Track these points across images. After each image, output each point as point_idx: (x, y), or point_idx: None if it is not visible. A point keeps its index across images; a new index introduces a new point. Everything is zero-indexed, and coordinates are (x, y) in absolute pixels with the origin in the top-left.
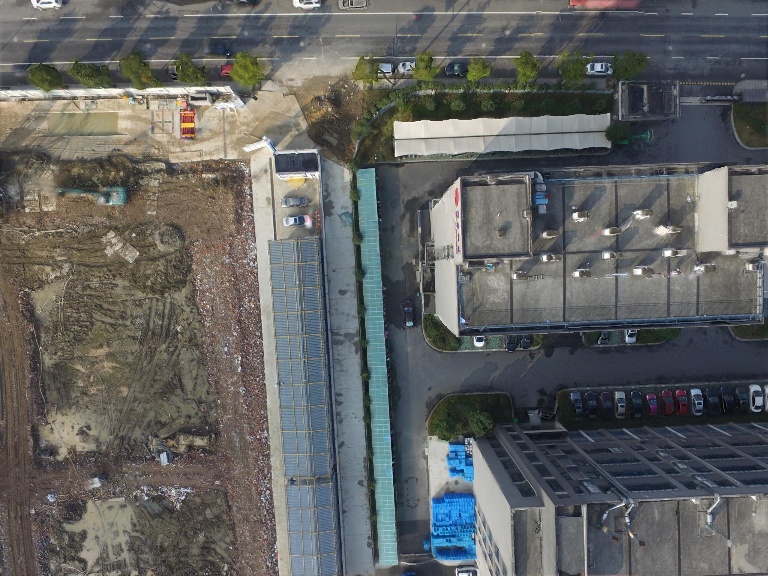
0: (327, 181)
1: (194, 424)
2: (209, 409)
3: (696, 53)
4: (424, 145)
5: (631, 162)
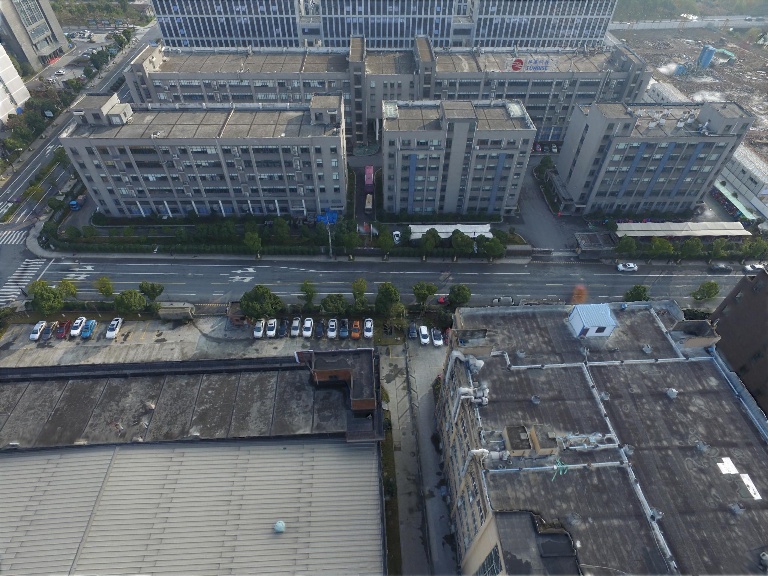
0: (767, 223)
1: (765, 147)
2: (762, 151)
3: (563, 277)
4: (726, 226)
5: (586, 228)
